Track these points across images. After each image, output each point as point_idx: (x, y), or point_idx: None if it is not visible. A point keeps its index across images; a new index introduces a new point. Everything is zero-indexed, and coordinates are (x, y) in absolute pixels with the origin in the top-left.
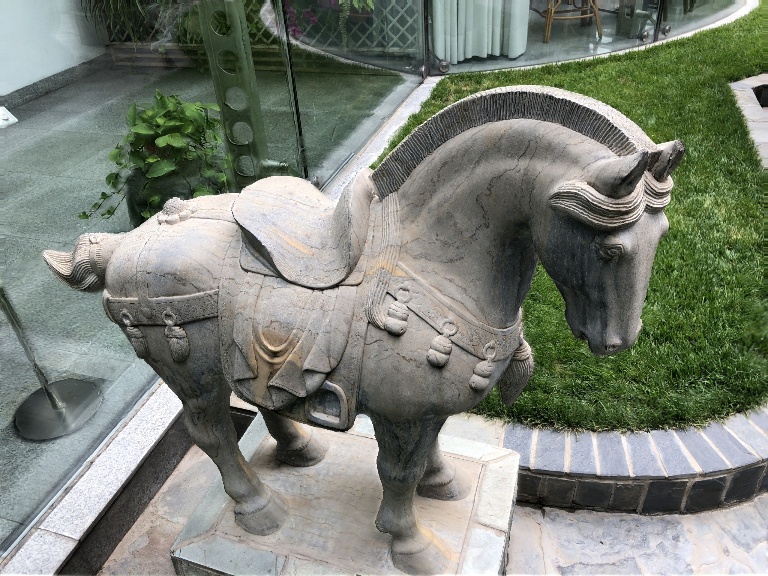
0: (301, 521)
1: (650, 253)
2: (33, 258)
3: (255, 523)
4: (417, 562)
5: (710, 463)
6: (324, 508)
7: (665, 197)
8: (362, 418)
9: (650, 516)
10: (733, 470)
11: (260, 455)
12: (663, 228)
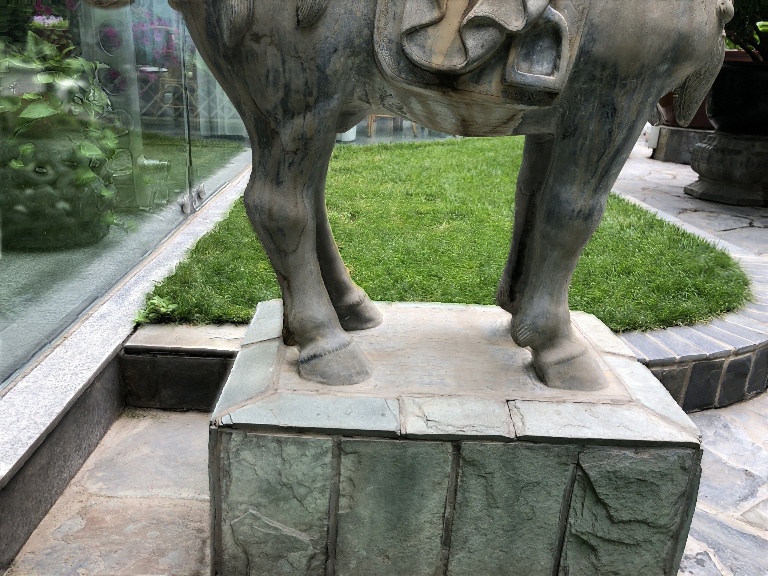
0: (395, 367)
1: None
2: None
3: (340, 366)
4: (581, 368)
5: (737, 341)
6: (417, 355)
7: None
8: None
9: (691, 413)
10: (756, 347)
11: None
12: None
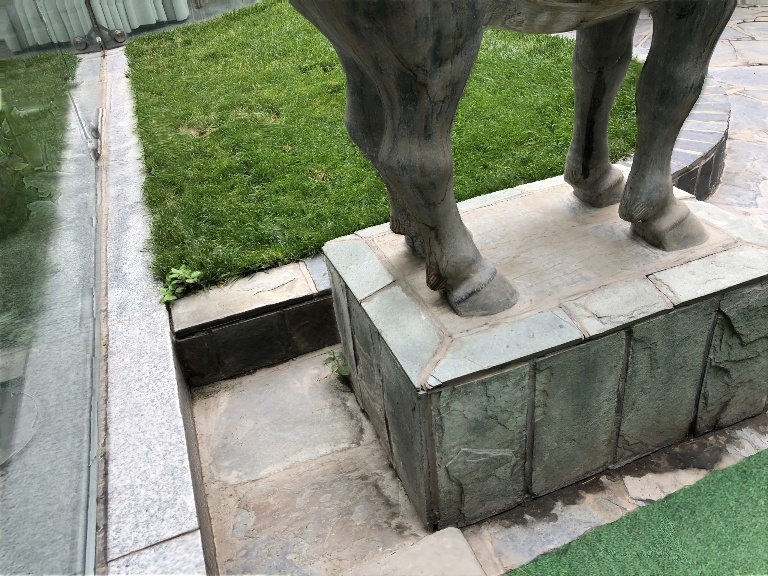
0: (530, 277)
1: None
2: None
3: (497, 294)
4: (691, 227)
5: (702, 147)
6: (536, 257)
7: None
8: None
9: None
10: (716, 147)
11: (397, 267)
12: None
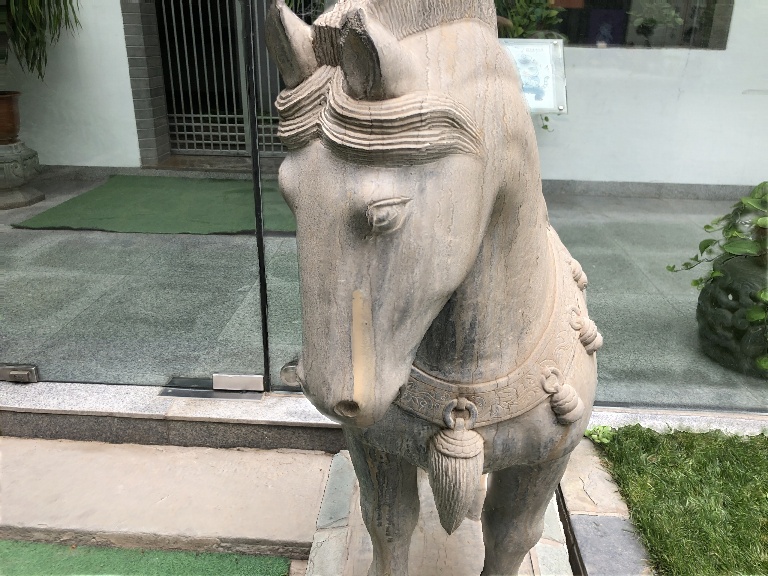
0: None
1: (324, 229)
2: (628, 288)
3: None
4: None
5: None
6: None
7: (354, 132)
8: (564, 549)
9: None
10: None
11: None
12: (355, 200)
